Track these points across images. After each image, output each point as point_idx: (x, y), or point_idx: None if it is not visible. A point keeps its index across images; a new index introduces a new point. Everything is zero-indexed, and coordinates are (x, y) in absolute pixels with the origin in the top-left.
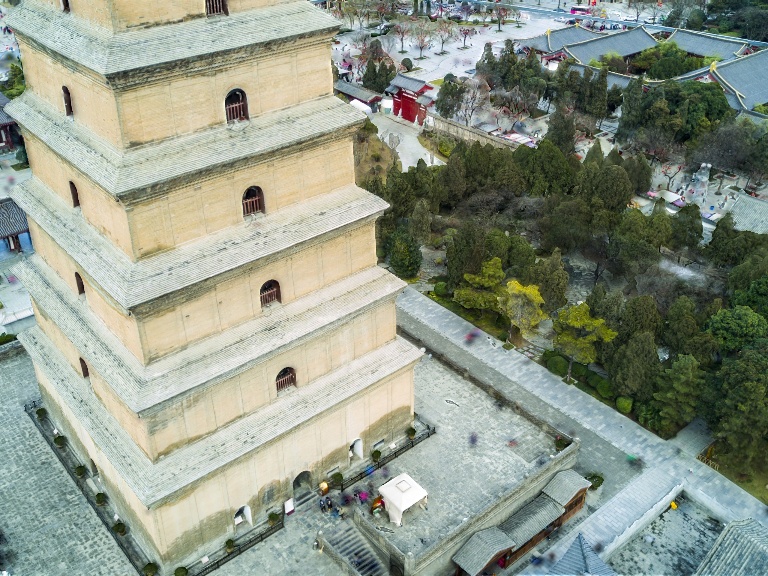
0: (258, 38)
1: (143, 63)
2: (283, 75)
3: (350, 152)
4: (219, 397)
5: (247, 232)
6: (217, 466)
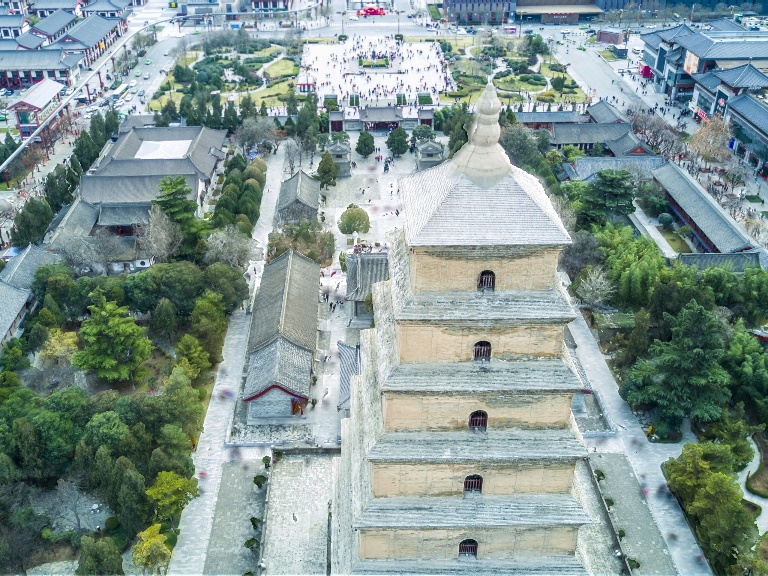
0: None
1: None
2: None
3: None
4: None
5: None
6: None
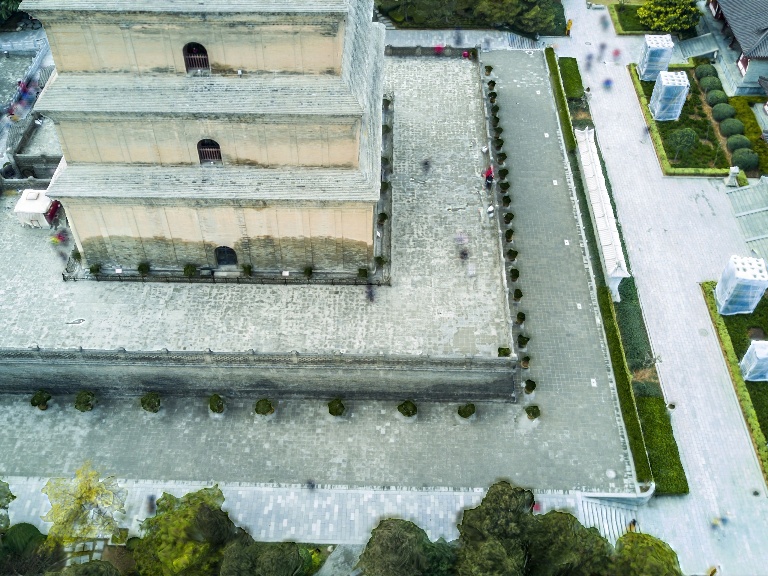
0: None
1: None
2: None
3: None
4: None
5: None
6: None
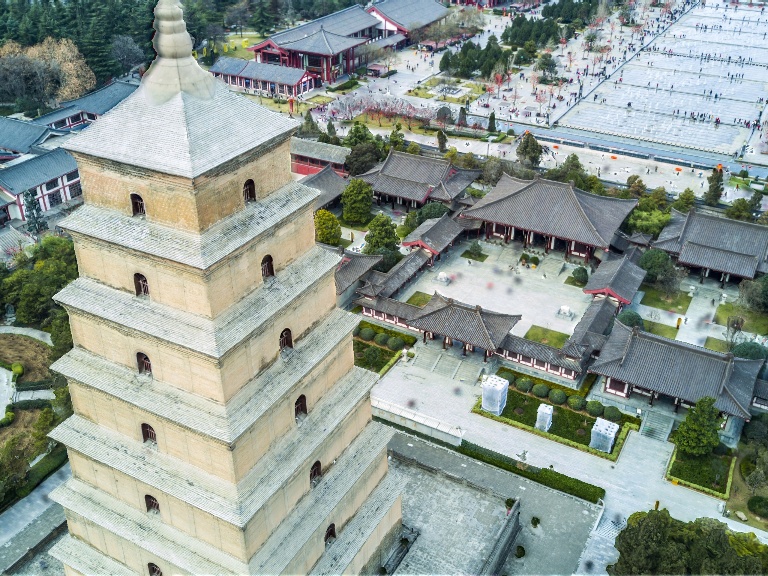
0: (149, 329)
1: (74, 304)
2: (179, 365)
3: (229, 458)
4: (108, 537)
5: (140, 451)
6: (89, 575)
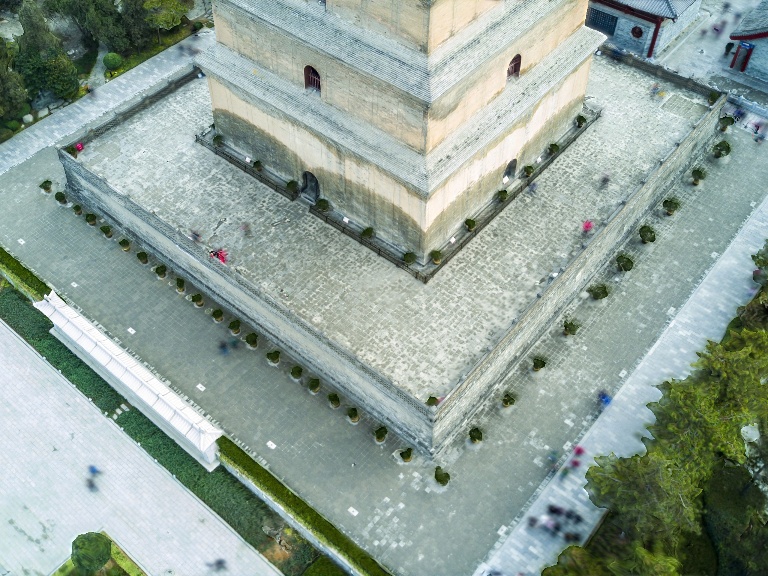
0: None
1: None
2: None
3: None
4: None
5: None
6: None
